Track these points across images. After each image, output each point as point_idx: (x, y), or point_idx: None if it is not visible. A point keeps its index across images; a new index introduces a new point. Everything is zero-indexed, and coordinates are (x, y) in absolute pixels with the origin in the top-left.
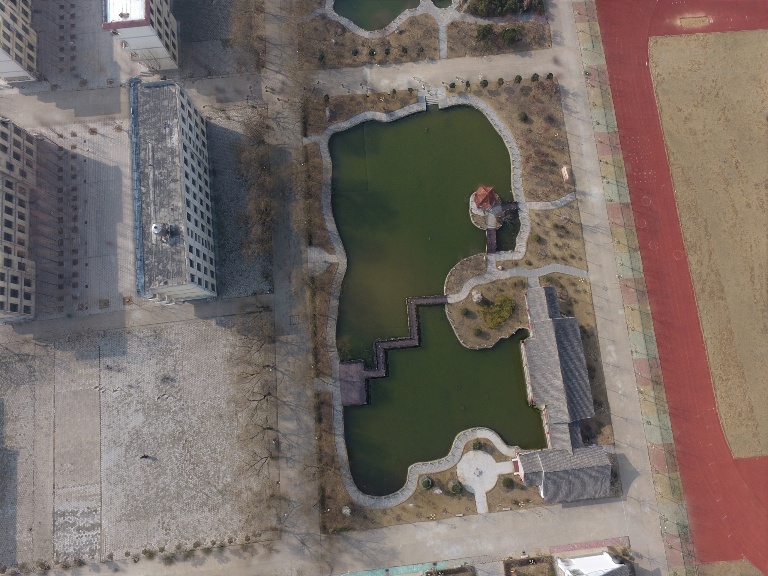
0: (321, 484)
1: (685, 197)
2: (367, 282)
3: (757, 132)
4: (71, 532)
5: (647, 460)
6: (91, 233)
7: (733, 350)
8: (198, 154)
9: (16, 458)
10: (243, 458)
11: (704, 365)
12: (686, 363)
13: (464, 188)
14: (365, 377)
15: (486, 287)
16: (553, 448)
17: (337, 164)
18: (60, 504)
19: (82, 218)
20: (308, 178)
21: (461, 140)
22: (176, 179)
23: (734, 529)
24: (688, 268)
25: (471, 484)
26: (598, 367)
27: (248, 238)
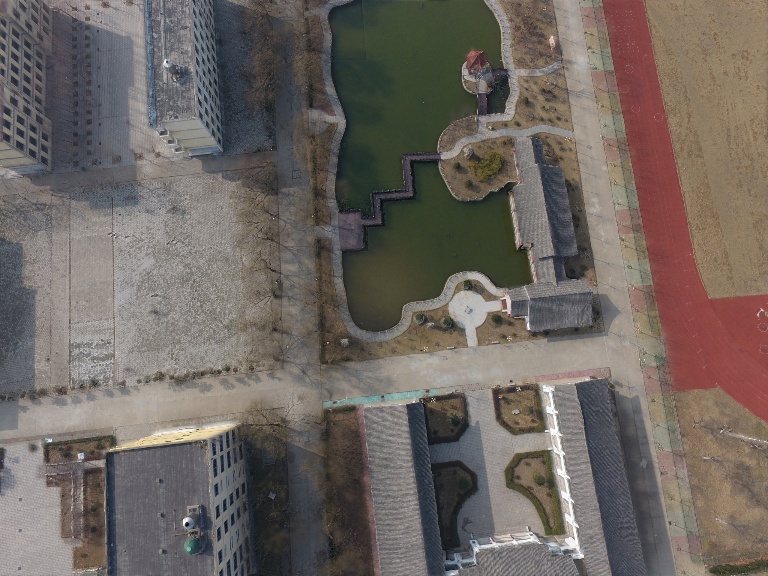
0: (321, 320)
1: (666, 66)
2: (365, 142)
3: (735, 7)
4: (86, 362)
5: (628, 300)
6: (104, 96)
7: (710, 202)
8: (206, 17)
9: (34, 296)
10: (248, 297)
11: (682, 216)
12: (665, 214)
13: (457, 58)
14: (362, 224)
15: (477, 145)
16: (539, 281)
17: (337, 35)
18: (76, 337)
19: (95, 83)
20: (309, 47)
21: (454, 14)
22: (186, 26)
23: (709, 361)
24: (668, 129)
25: (462, 320)
26: (582, 217)
27: (252, 101)
